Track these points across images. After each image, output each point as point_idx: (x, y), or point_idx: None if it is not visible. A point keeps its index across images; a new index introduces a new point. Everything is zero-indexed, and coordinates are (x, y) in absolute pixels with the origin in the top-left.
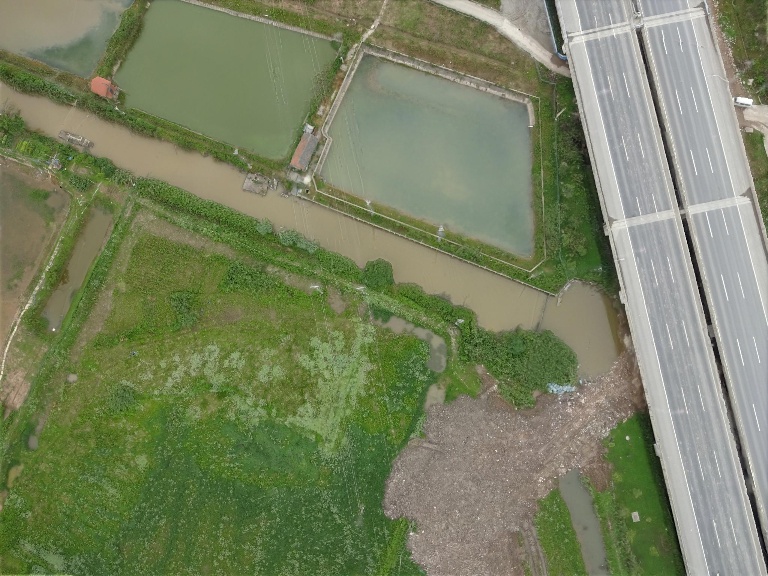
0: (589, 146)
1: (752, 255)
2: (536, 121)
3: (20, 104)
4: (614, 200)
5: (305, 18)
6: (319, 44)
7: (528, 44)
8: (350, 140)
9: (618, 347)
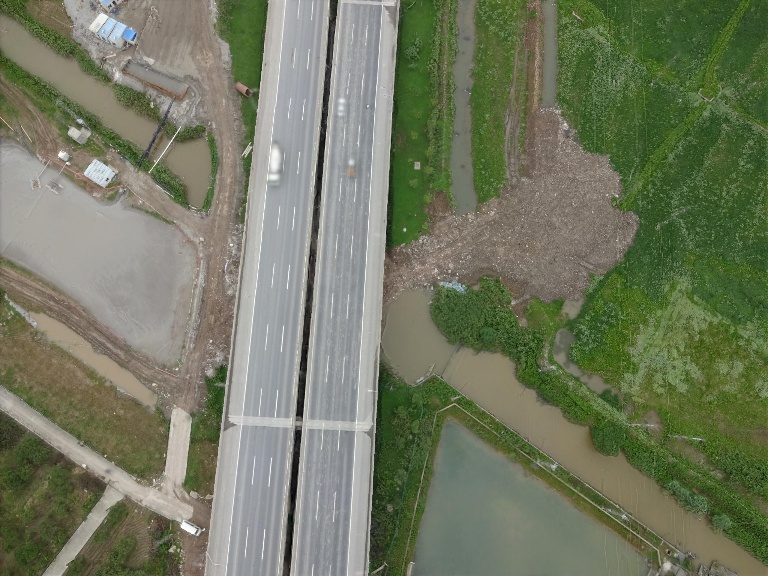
0: None
1: (246, 363)
2: (407, 567)
3: None
4: (361, 454)
5: None
6: None
7: None
8: None
9: (388, 311)
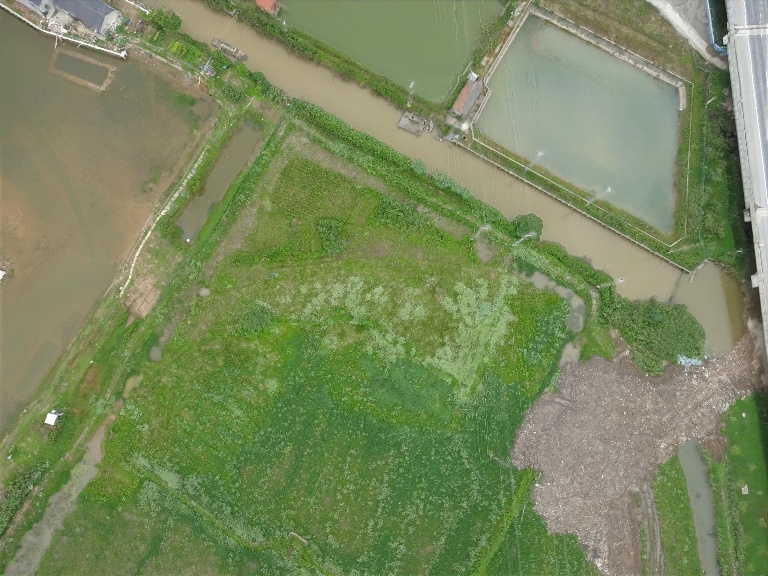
0: (743, 134)
1: None
2: (688, 105)
3: (173, 3)
4: (760, 188)
5: None
6: None
7: (687, 31)
8: (508, 95)
9: (742, 329)
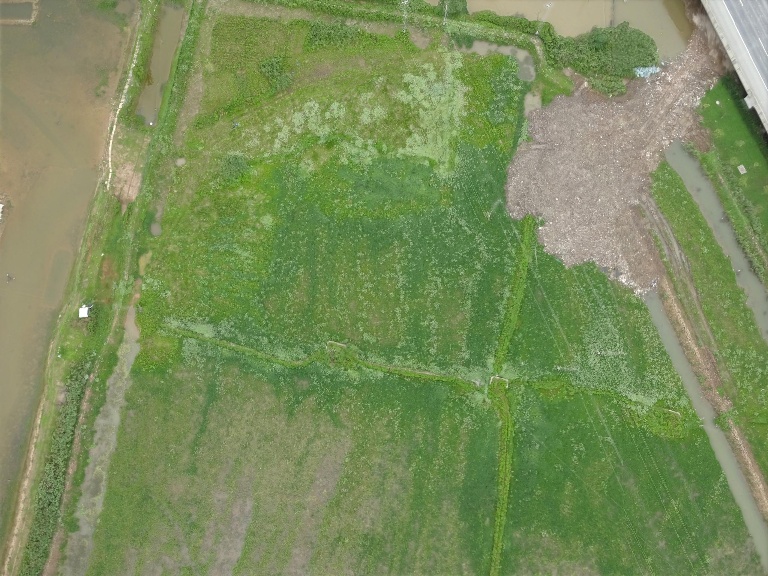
0: None
1: None
2: None
3: None
4: None
5: None
6: None
7: None
8: None
9: (689, 27)
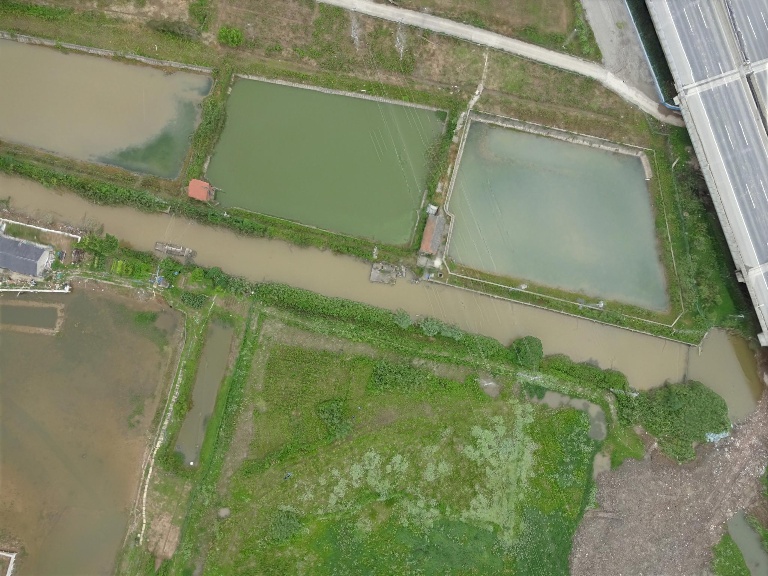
0: (718, 198)
1: None
2: (654, 174)
3: (102, 218)
4: (747, 248)
5: (407, 90)
6: (423, 116)
7: (634, 96)
8: (472, 214)
9: (759, 386)
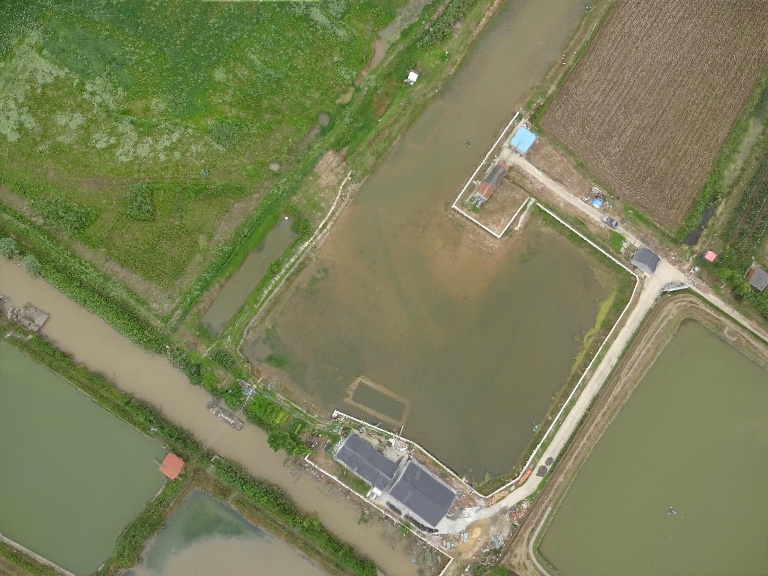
0: None
1: None
2: None
3: (281, 473)
4: None
5: None
6: None
7: None
8: None
9: None
